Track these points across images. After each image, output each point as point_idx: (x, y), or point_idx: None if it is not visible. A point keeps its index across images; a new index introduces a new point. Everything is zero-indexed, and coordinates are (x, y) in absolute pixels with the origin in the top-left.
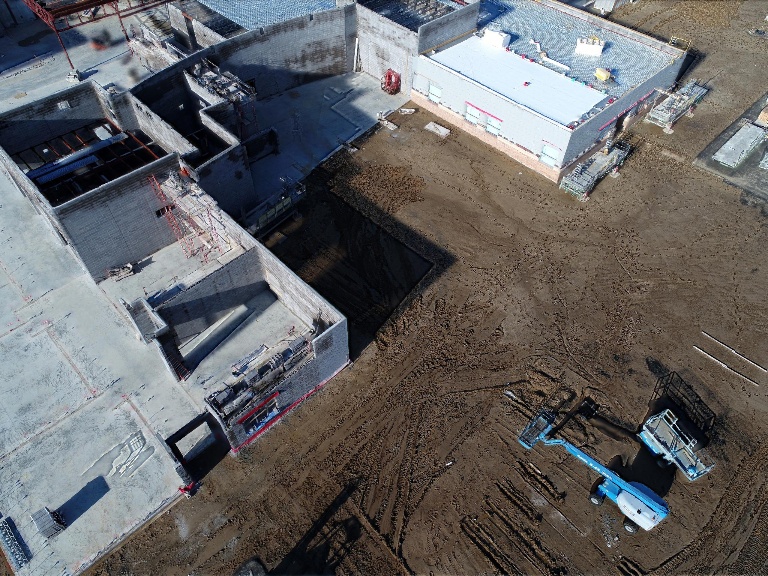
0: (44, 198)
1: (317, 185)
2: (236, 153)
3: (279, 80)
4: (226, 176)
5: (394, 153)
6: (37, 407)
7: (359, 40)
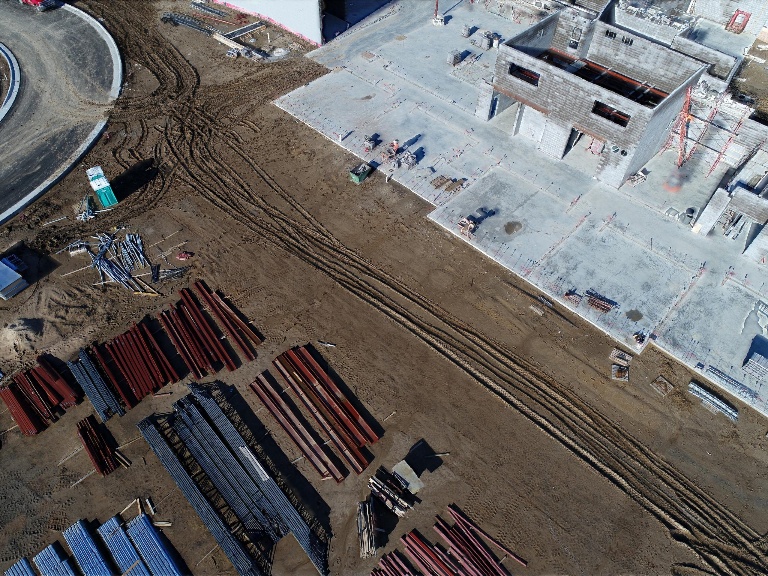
0: (635, 102)
1: None
2: None
3: None
4: None
5: None
6: (656, 284)
7: None
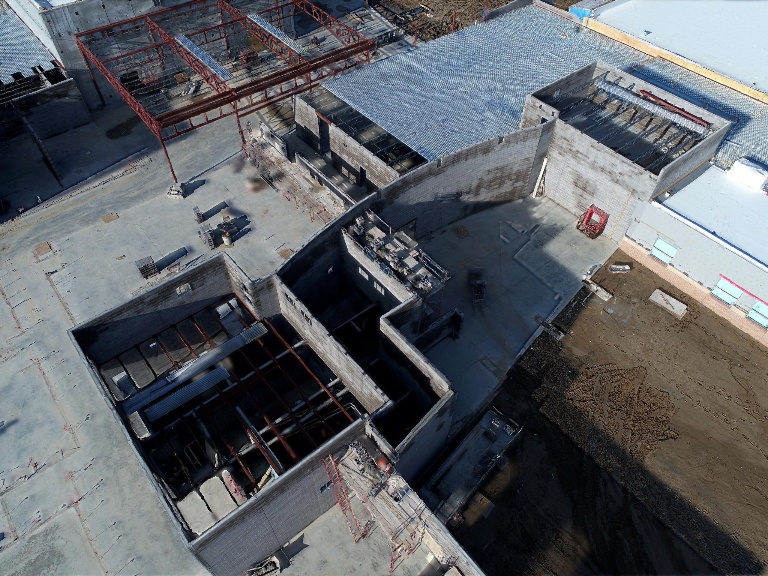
0: (173, 518)
1: (519, 399)
2: (446, 406)
3: (444, 214)
4: (426, 436)
5: (616, 343)
6: None
7: (549, 161)
